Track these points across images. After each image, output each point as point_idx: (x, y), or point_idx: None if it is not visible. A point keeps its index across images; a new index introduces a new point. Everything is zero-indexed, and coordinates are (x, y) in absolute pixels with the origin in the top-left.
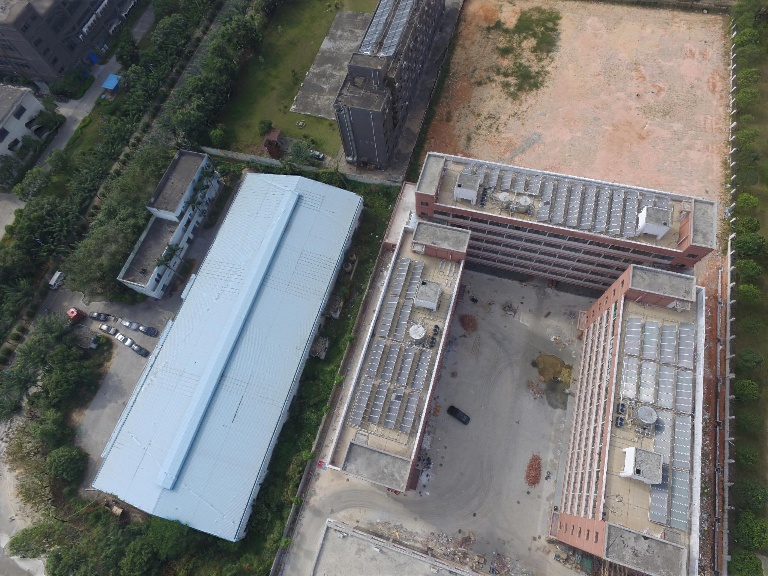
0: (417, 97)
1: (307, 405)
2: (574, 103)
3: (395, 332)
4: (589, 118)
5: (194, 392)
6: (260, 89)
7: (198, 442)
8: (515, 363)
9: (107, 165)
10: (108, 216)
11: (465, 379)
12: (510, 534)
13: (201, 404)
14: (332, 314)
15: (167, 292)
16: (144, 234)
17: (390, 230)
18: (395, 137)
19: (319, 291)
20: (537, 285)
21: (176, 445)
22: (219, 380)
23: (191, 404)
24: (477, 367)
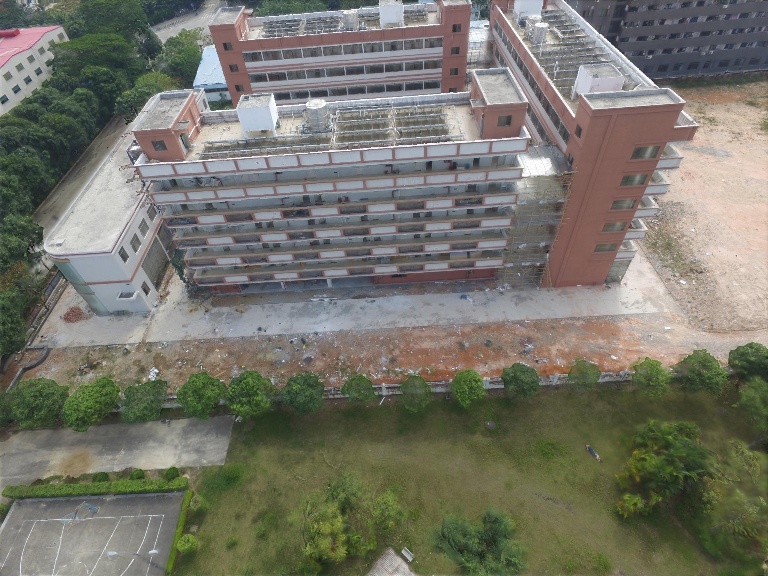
0: None
1: None
2: None
3: None
4: None
5: None
6: None
7: None
8: None
9: None
10: None
11: None
12: None
13: None
14: None
15: None
16: None
17: None
18: None
19: None
20: None
21: None
22: None
23: None
24: None
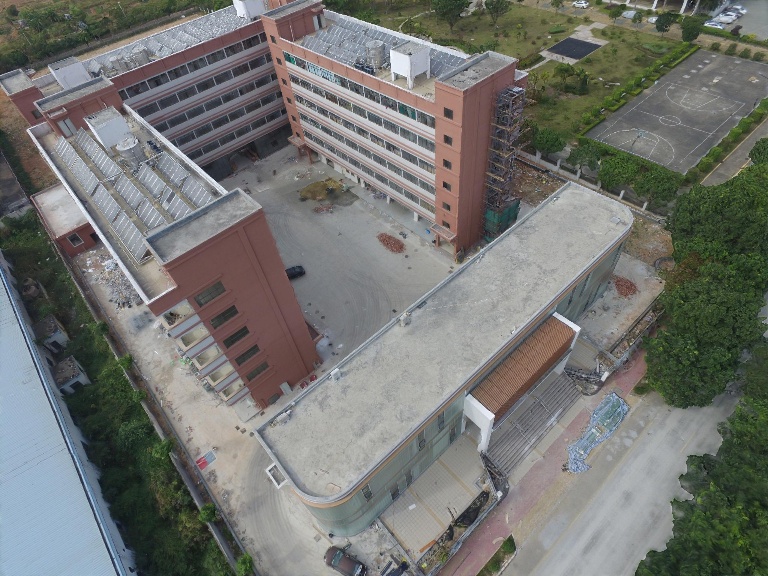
0: None
1: (114, 434)
2: None
3: None
4: None
5: None
6: None
7: None
8: (289, 211)
9: None
10: None
11: None
12: None
13: None
14: (53, 335)
15: None
16: None
17: (52, 230)
18: None
19: (3, 320)
20: (244, 167)
21: None
22: None
23: None
24: None
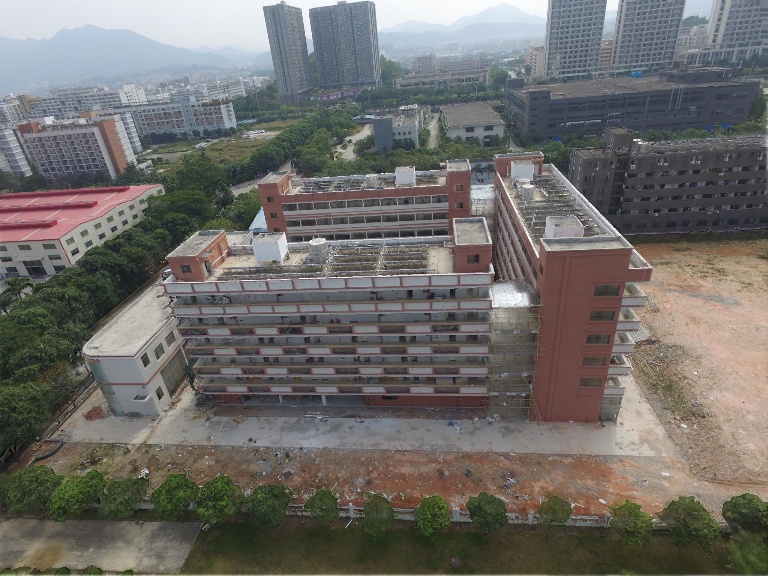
0: None
1: None
2: None
3: None
4: None
5: None
6: None
7: None
8: None
9: None
10: None
11: None
12: None
13: None
14: None
15: None
16: None
17: None
18: None
19: None
20: None
21: None
22: None
23: None
24: None
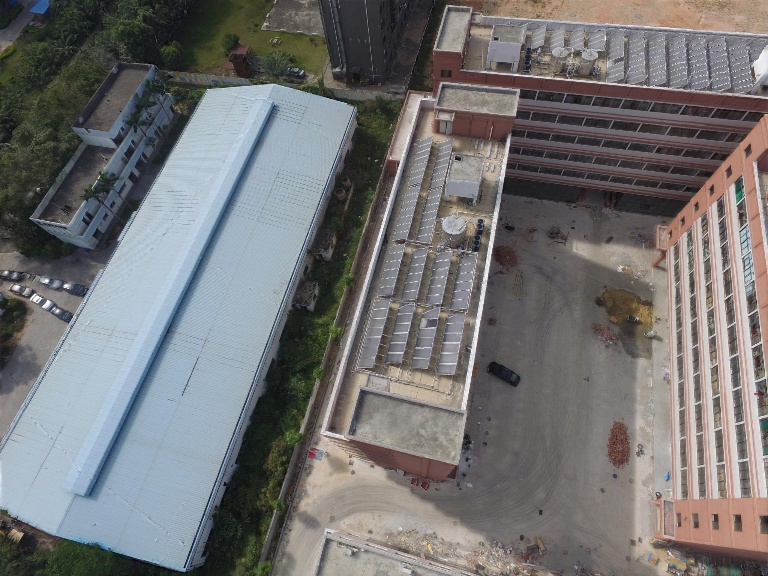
0: (416, 6)
1: (291, 371)
2: (609, 2)
3: (418, 234)
4: (629, 16)
5: (127, 354)
6: (225, 9)
7: (131, 424)
8: (573, 302)
9: (29, 93)
10: (22, 143)
11: (508, 327)
12: (596, 538)
13: (136, 370)
14: (322, 251)
15: (103, 241)
16: (70, 164)
17: (394, 146)
18: (393, 45)
19: (303, 219)
20: (590, 205)
21: (96, 429)
22: (164, 337)
23: (121, 371)
24: (522, 310)
